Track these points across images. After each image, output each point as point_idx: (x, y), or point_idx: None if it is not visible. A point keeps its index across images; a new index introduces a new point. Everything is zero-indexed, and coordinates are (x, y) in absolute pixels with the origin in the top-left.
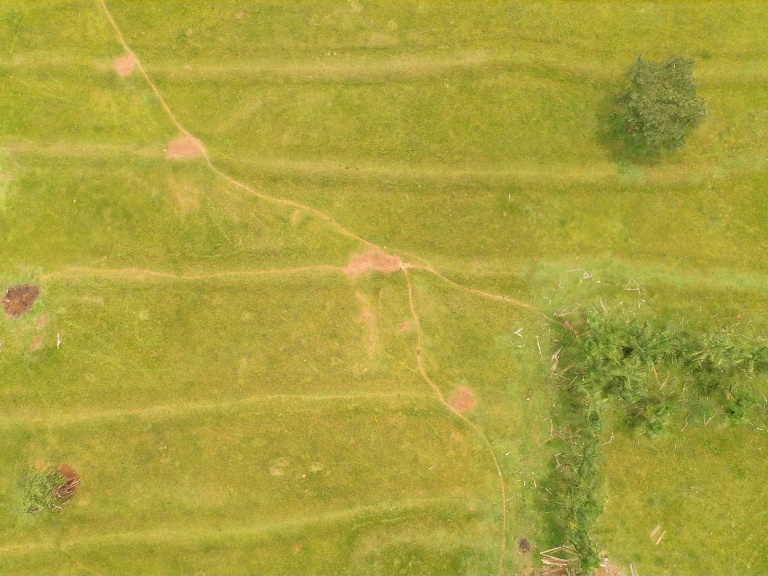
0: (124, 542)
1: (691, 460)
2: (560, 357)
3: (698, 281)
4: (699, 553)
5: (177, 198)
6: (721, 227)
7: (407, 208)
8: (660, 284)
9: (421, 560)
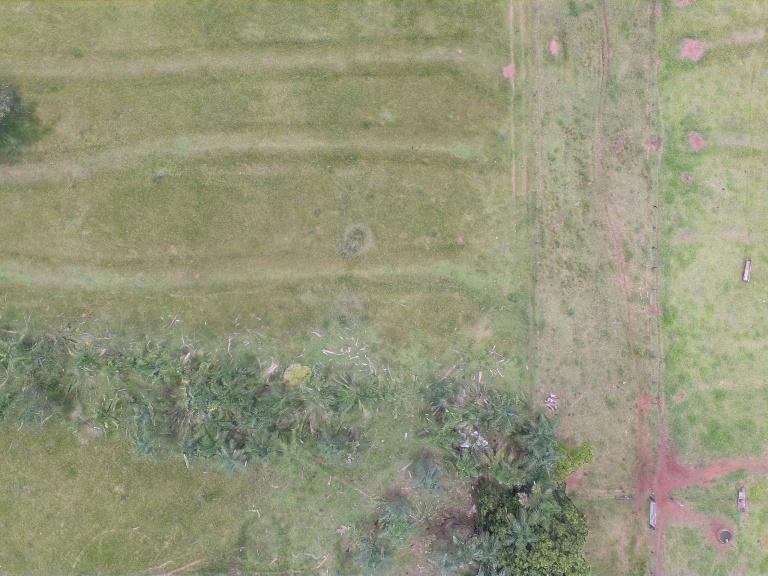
0: None
1: (25, 460)
2: None
3: (46, 280)
4: (26, 553)
5: None
6: (76, 226)
7: None
8: (8, 283)
9: None
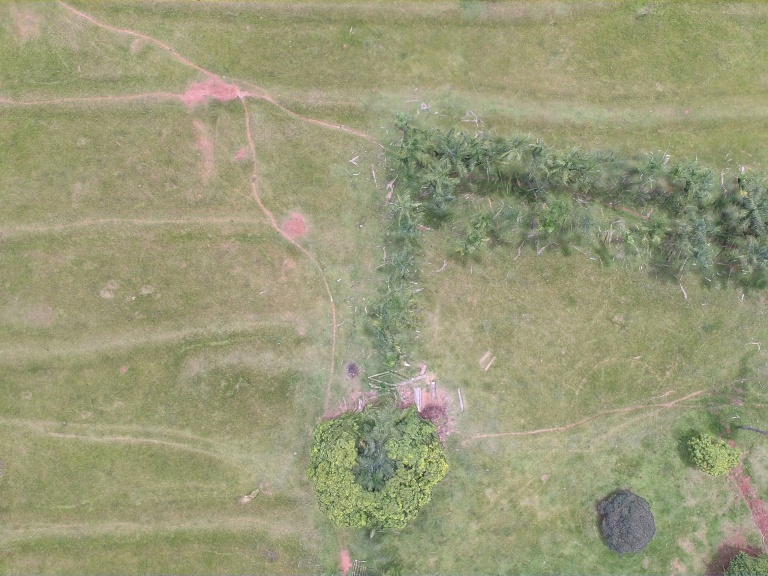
0: None
1: (523, 288)
2: (395, 186)
3: (536, 113)
4: (528, 380)
5: (18, 26)
6: (561, 61)
7: (247, 39)
8: (498, 116)
9: (248, 382)
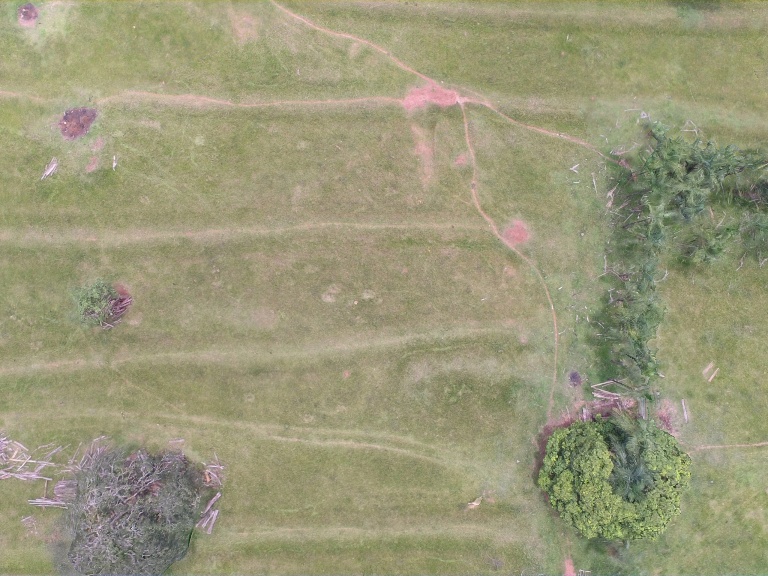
0: (174, 362)
1: (746, 300)
2: (615, 195)
3: (756, 124)
4: (752, 392)
5: (236, 28)
6: None
7: (465, 44)
8: (718, 126)
9: (471, 389)
